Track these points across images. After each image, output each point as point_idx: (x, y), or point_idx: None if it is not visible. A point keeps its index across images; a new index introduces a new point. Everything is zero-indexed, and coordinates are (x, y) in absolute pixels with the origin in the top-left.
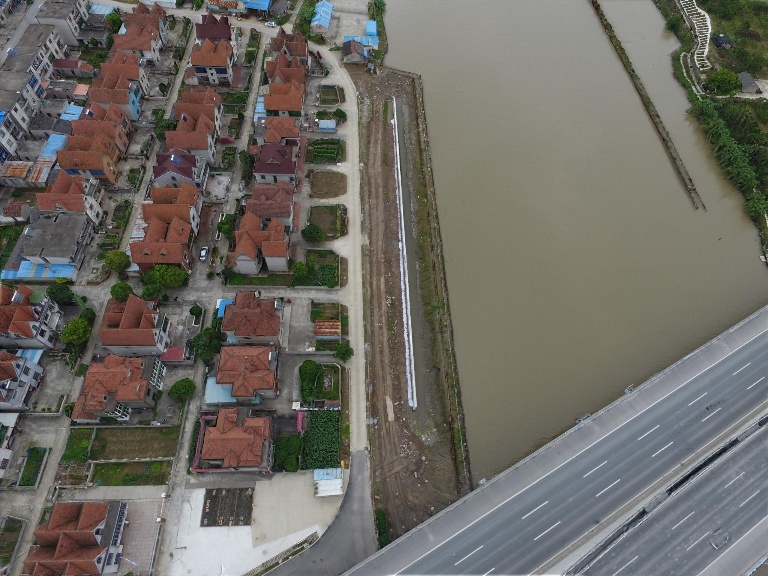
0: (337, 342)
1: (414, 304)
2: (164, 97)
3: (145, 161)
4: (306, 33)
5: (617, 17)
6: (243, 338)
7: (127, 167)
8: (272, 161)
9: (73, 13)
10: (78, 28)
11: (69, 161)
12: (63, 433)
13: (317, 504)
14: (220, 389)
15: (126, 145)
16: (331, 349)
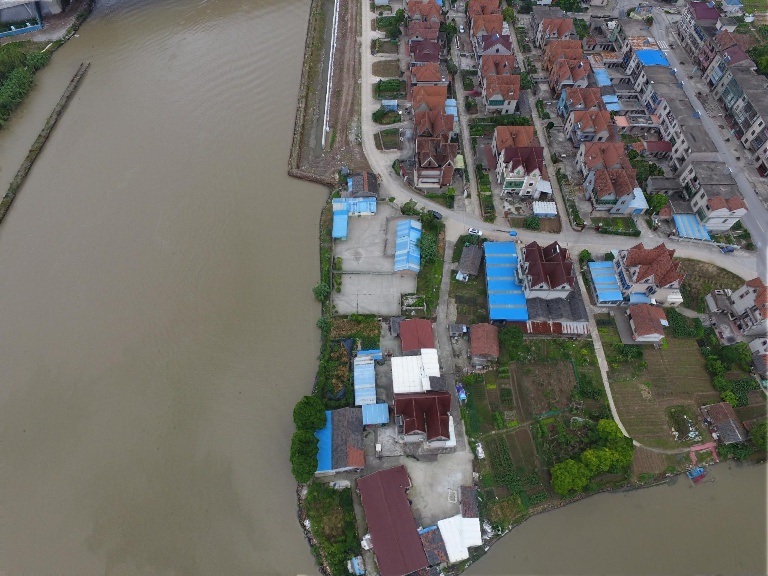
0: None
1: None
2: None
3: None
4: None
5: None
6: None
7: (541, 75)
8: None
9: None
10: None
11: None
12: None
13: None
14: None
15: None
16: None
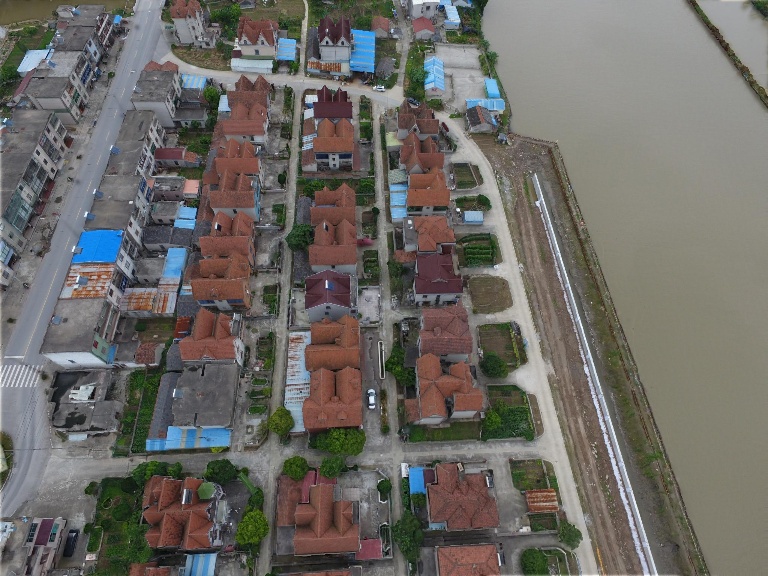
0: (553, 517)
1: (620, 450)
2: (283, 189)
3: (278, 275)
4: (422, 98)
5: (748, 57)
6: None
7: (259, 284)
8: (438, 280)
9: (169, 91)
10: (174, 108)
11: (205, 291)
12: None
13: None
14: None
15: (254, 256)
16: (547, 526)
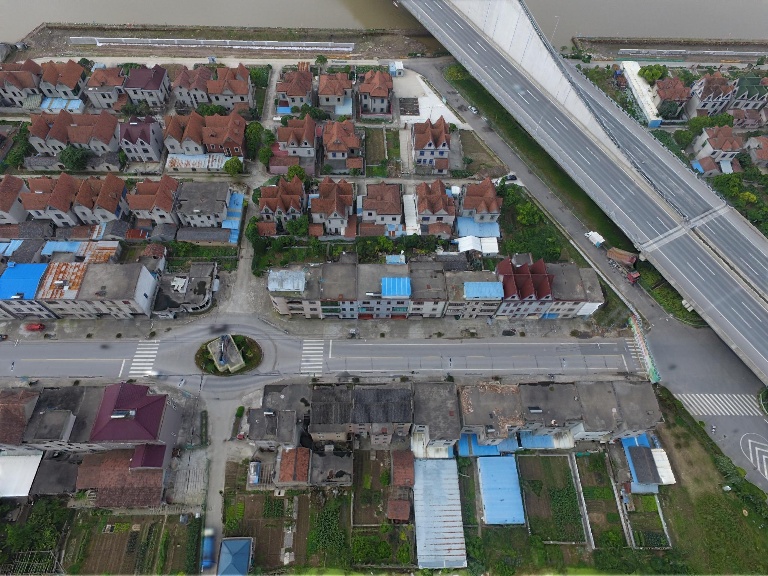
0: (312, 67)
1: None
2: None
3: None
4: None
5: None
6: (310, 93)
7: None
8: (152, 73)
9: None
10: None
11: (109, 201)
12: (369, 181)
13: (406, 76)
14: (343, 107)
15: None
16: None
